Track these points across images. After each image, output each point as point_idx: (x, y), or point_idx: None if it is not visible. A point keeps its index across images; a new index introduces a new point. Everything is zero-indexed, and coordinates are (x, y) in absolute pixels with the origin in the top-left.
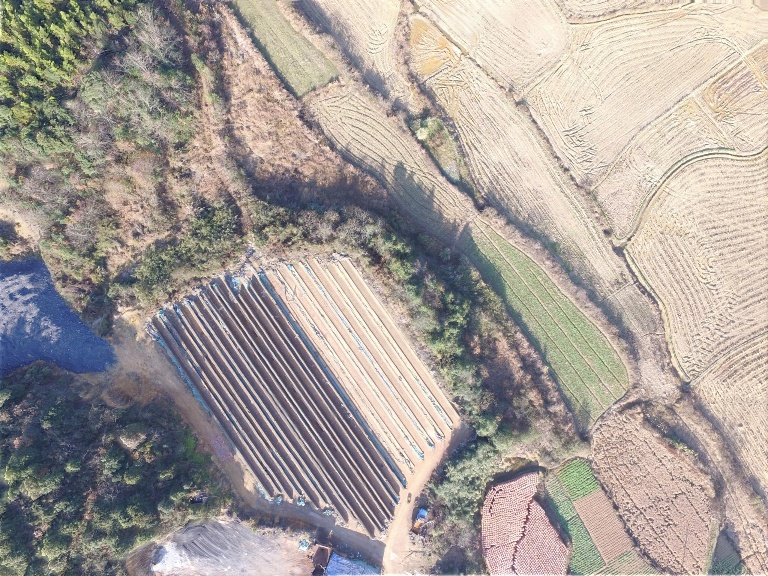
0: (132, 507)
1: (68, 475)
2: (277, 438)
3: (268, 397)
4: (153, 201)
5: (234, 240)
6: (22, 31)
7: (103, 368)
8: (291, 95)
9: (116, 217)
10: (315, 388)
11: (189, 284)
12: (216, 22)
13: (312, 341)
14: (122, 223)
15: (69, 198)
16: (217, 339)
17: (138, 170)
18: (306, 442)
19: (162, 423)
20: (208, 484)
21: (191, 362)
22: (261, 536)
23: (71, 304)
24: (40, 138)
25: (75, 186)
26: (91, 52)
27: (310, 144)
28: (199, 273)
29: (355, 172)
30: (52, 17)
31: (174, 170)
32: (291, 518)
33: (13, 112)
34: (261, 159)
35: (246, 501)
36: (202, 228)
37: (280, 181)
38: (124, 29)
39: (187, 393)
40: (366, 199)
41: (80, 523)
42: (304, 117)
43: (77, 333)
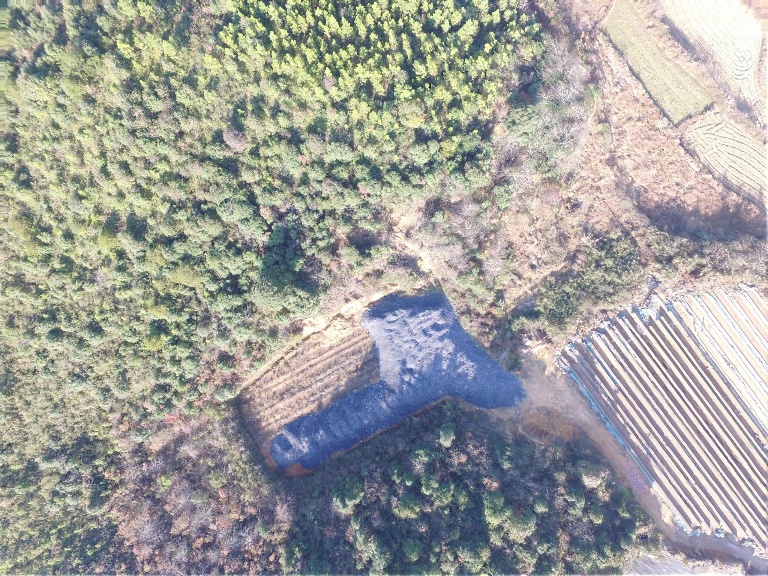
0: (608, 547)
1: (537, 516)
2: (693, 470)
3: (682, 429)
4: (550, 233)
5: (640, 272)
6: (449, 64)
7: (513, 403)
8: (671, 123)
9: (512, 249)
10: (730, 419)
11: (597, 317)
12: (595, 50)
13: (723, 372)
14: (517, 255)
15: (485, 232)
16: (630, 372)
17: (548, 203)
18: (725, 474)
19: (601, 459)
20: (650, 520)
21: (605, 396)
22: (691, 569)
23: (476, 338)
24: (474, 173)
25: (491, 220)
26: (509, 84)
27: (693, 172)
28: (609, 306)
29: (738, 200)
30: (476, 49)
31: (564, 201)
32: (711, 550)
33: (441, 146)
34: (644, 188)
35: (665, 534)
36: (605, 260)
37: (667, 210)
38: (532, 60)
39: (600, 427)
40: (751, 227)
41: (559, 565)
42: (684, 145)
43: (488, 368)
